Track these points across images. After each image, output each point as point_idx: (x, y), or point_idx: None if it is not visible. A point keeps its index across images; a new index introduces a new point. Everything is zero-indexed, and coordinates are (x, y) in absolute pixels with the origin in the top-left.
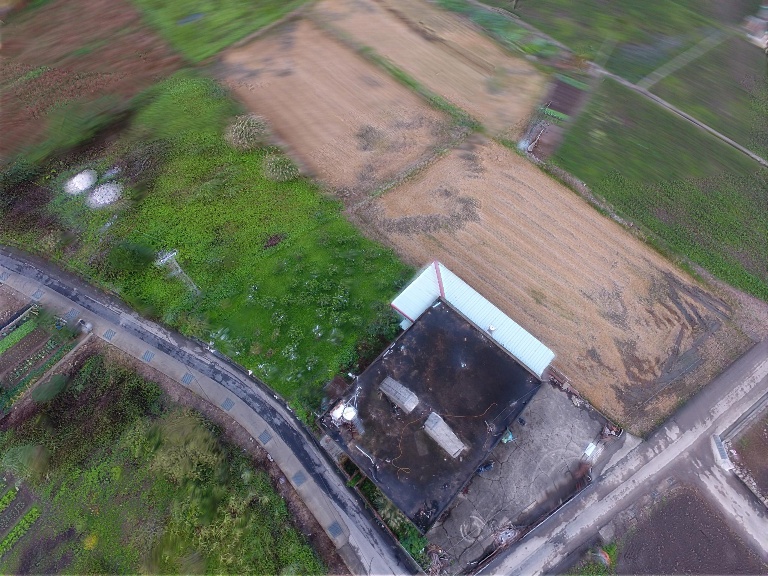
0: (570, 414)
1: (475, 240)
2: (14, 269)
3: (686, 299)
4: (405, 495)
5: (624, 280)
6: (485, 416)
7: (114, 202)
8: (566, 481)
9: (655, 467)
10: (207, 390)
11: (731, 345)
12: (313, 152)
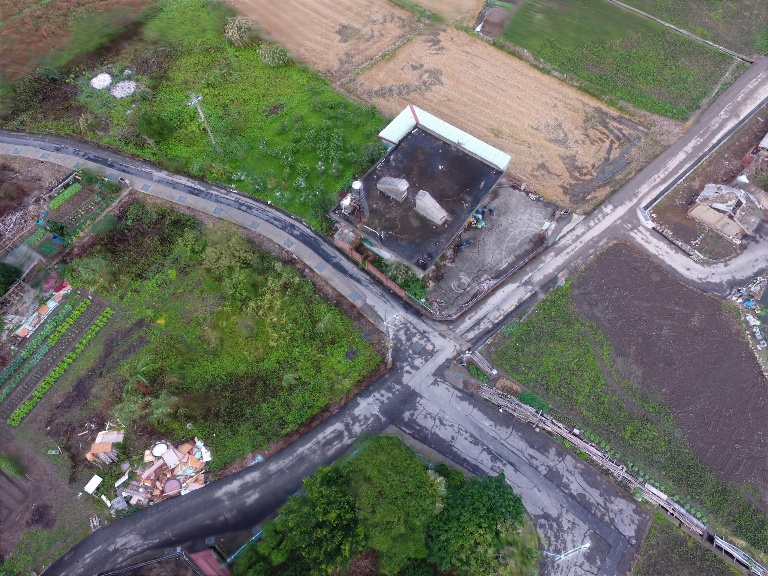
0: (528, 205)
1: (440, 98)
2: (53, 150)
3: (612, 124)
4: (406, 252)
5: (563, 115)
6: (461, 198)
7: (130, 96)
8: (529, 248)
9: (596, 232)
10: (236, 217)
11: (649, 151)
12: (296, 47)
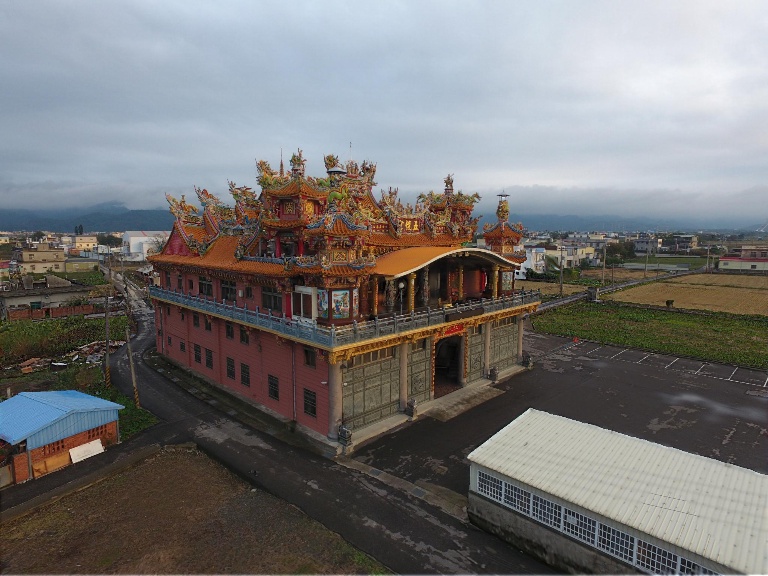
0: None
1: None
2: None
3: None
4: None
5: None
6: None
7: None
8: None
9: None
10: None
11: None
12: None
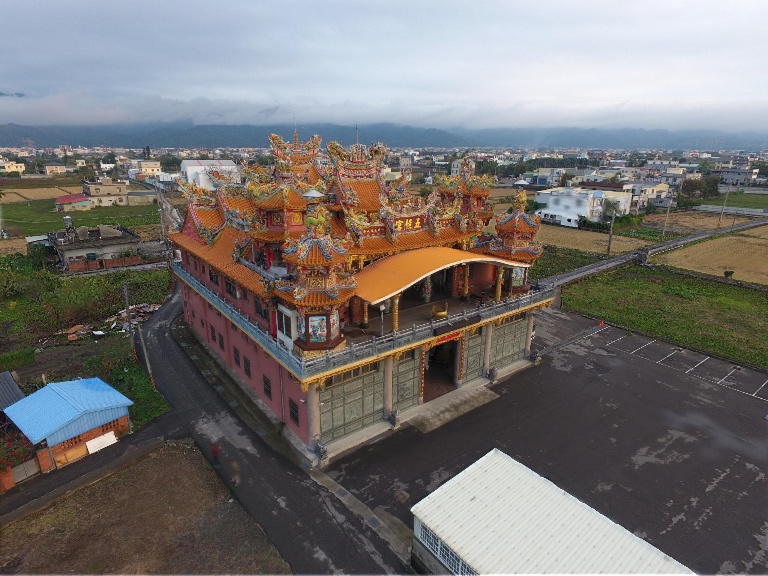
0: None
1: None
2: None
3: None
4: None
5: None
6: None
7: None
8: None
9: None
10: None
11: None
12: None
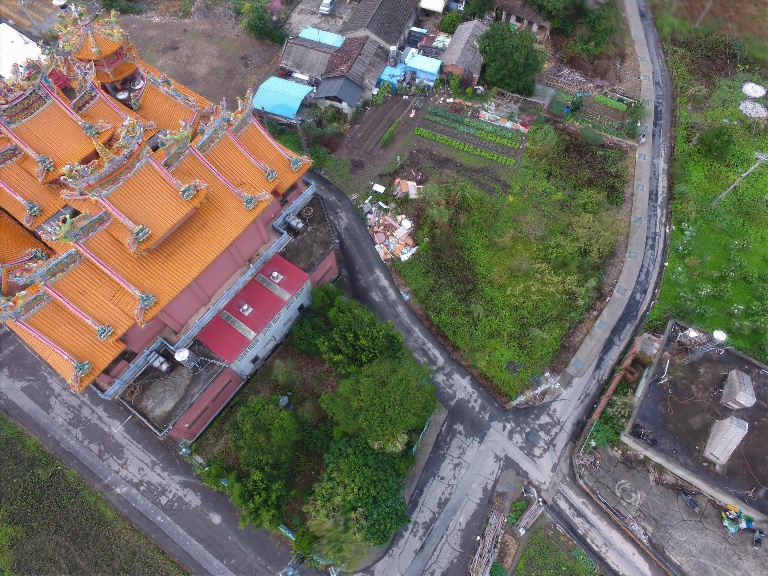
0: None
1: None
2: (655, 80)
3: None
4: (649, 412)
5: None
6: (760, 487)
7: (747, 116)
8: None
9: None
10: (636, 236)
11: None
12: None
